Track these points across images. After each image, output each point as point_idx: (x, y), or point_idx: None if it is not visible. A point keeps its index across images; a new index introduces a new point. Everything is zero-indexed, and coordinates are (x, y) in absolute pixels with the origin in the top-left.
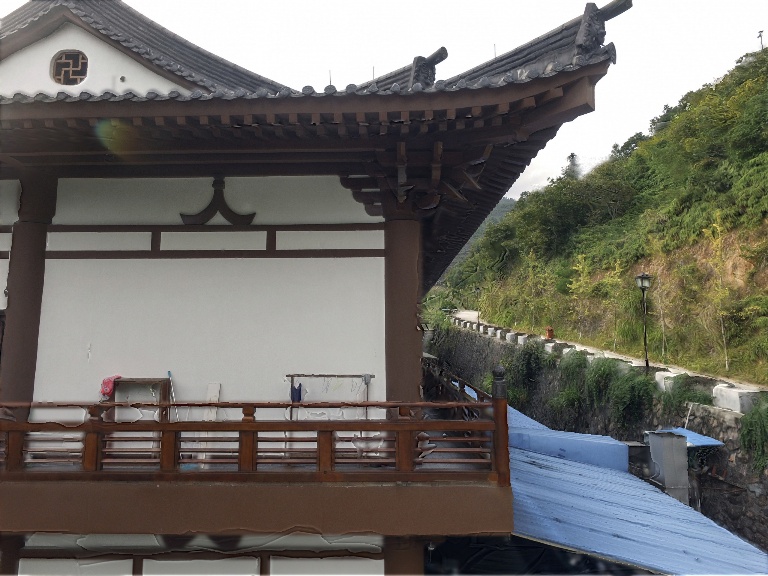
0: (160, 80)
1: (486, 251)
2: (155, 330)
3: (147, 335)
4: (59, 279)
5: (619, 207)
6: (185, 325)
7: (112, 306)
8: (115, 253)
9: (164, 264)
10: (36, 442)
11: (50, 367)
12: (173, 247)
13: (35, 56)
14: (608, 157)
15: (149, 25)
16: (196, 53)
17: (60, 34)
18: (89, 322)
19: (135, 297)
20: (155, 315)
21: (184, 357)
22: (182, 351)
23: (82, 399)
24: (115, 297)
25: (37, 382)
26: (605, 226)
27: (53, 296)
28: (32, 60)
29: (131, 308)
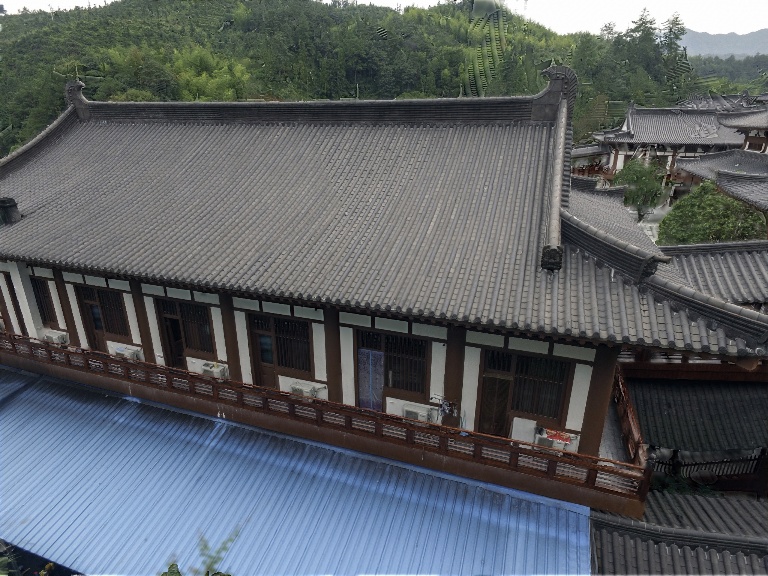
0: None
1: None
2: None
3: None
4: None
5: None
6: None
7: None
8: None
9: None
10: None
11: None
12: None
13: None
14: None
15: None
16: None
17: None
18: None
19: None
20: None
21: None
22: None
23: None
24: None
25: None
26: None
27: None
28: None
29: None
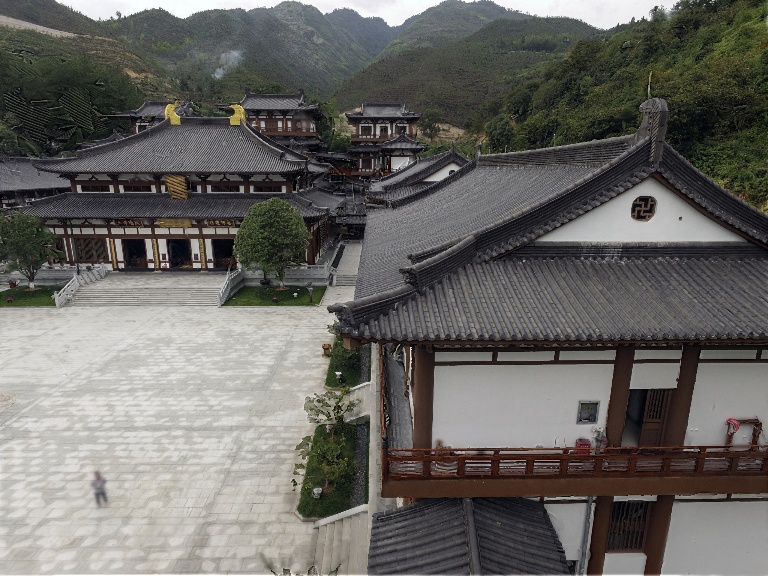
0: (705, 220)
1: (584, 140)
2: (750, 396)
3: (745, 399)
4: (706, 373)
5: (746, 118)
6: (766, 394)
7: (727, 384)
8: (737, 360)
9: (761, 366)
10: (742, 461)
11: (696, 414)
12: (767, 357)
13: (622, 201)
14: (694, 12)
15: (705, 181)
16: (735, 202)
17: (641, 185)
18: (715, 392)
19: (741, 381)
20: (751, 389)
21: (763, 409)
22: (762, 406)
23: (711, 428)
24: (730, 381)
25: (689, 421)
26: (735, 142)
27: (701, 381)
28: (621, 204)
29: (737, 385)
